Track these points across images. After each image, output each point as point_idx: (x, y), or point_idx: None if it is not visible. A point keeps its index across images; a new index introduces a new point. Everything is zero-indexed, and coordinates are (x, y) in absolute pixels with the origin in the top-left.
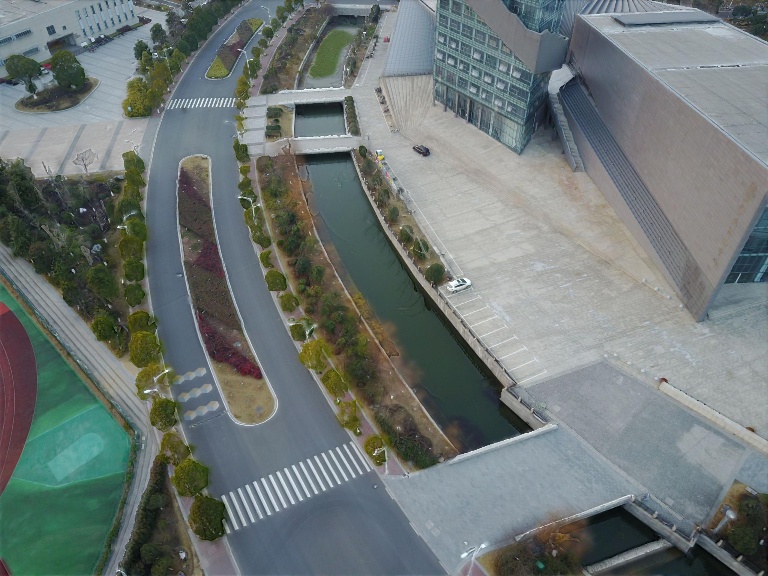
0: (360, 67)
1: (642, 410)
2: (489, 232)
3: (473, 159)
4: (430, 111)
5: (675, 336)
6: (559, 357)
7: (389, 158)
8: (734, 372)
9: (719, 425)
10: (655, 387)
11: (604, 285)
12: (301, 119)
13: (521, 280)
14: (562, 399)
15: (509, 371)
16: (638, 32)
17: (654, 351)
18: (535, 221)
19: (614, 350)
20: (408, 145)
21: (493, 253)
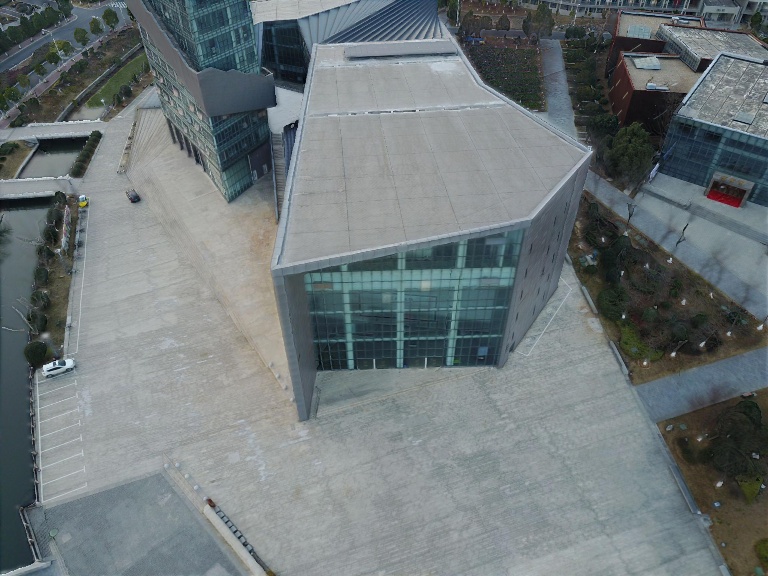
0: (137, 96)
1: (166, 542)
2: (141, 298)
3: (175, 208)
4: (166, 149)
5: (262, 440)
6: (113, 466)
7: (94, 204)
8: (304, 491)
9: (245, 565)
10: (200, 510)
11: (224, 369)
12: (39, 156)
13: (135, 361)
14: (80, 525)
15: (43, 484)
16: (353, 67)
17: (226, 460)
18: (200, 285)
19: (181, 458)
20: (125, 189)
21: (127, 325)
